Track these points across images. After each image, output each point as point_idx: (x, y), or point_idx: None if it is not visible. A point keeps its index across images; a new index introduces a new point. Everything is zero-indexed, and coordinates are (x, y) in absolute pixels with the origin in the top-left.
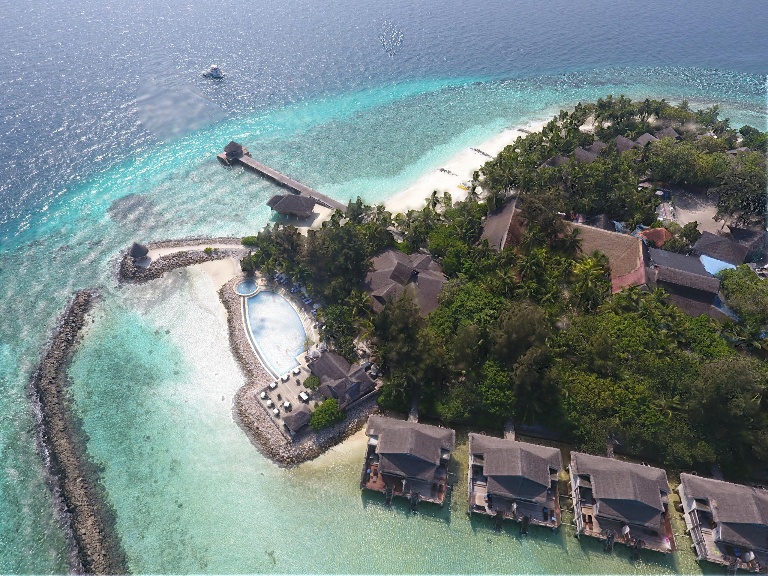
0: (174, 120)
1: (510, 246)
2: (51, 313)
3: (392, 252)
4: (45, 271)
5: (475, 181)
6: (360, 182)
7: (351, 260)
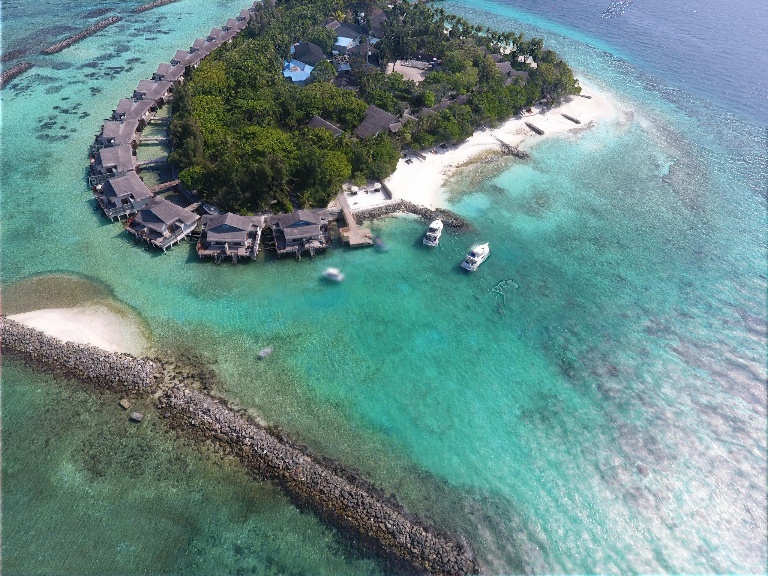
0: None
1: None
2: None
3: None
4: None
5: None
6: None
7: None
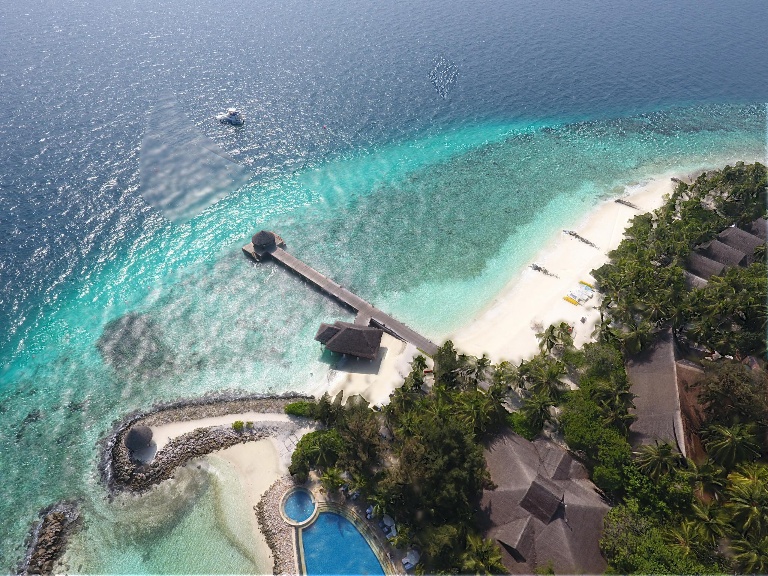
0: (186, 190)
1: (689, 439)
2: (4, 558)
3: (510, 442)
4: (2, 464)
5: (605, 309)
6: (431, 288)
7: (465, 484)
